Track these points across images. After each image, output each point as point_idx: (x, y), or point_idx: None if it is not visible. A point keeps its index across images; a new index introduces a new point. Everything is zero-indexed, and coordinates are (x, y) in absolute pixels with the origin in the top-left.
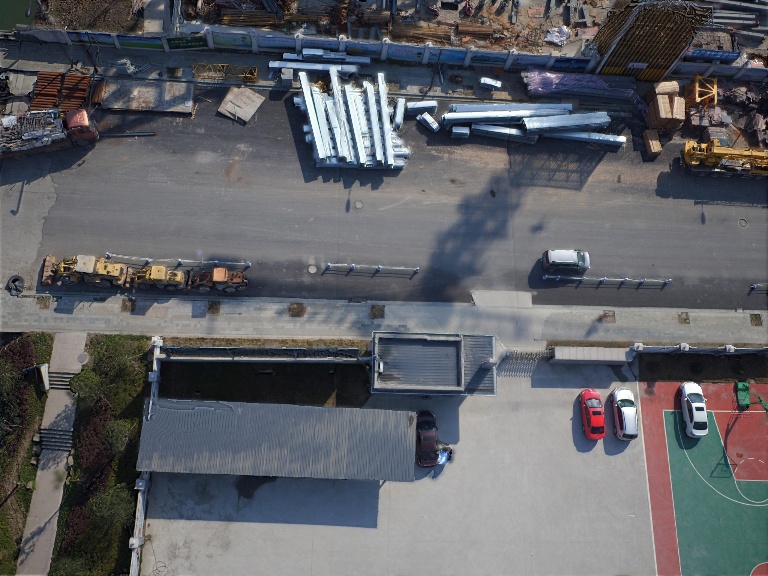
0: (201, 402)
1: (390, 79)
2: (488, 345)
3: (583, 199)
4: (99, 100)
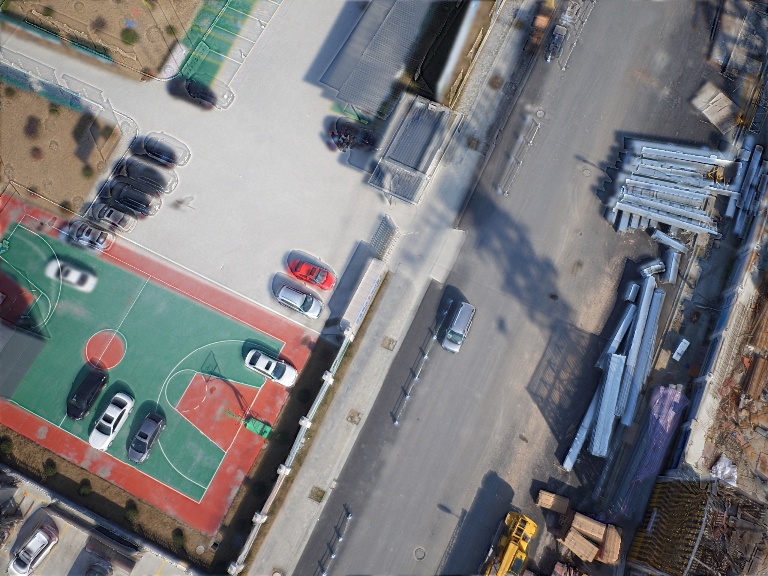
0: (467, 5)
1: (715, 255)
2: (412, 197)
3: (516, 386)
4: (757, 8)
